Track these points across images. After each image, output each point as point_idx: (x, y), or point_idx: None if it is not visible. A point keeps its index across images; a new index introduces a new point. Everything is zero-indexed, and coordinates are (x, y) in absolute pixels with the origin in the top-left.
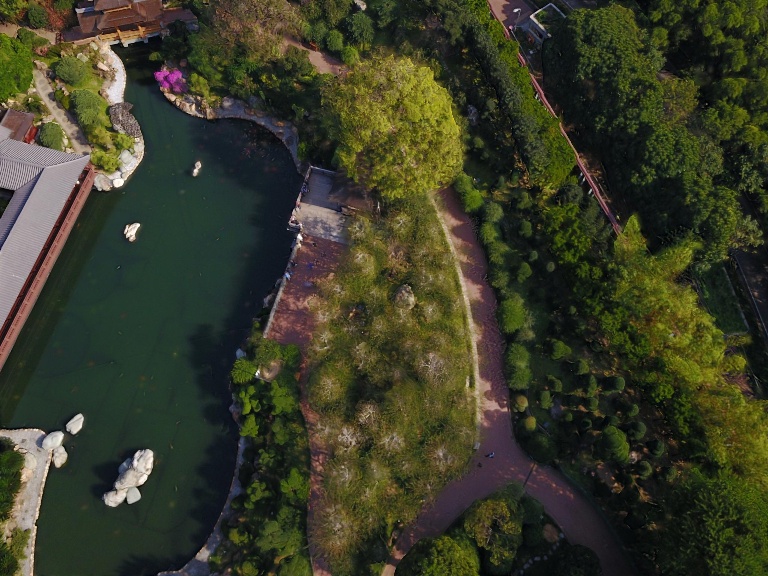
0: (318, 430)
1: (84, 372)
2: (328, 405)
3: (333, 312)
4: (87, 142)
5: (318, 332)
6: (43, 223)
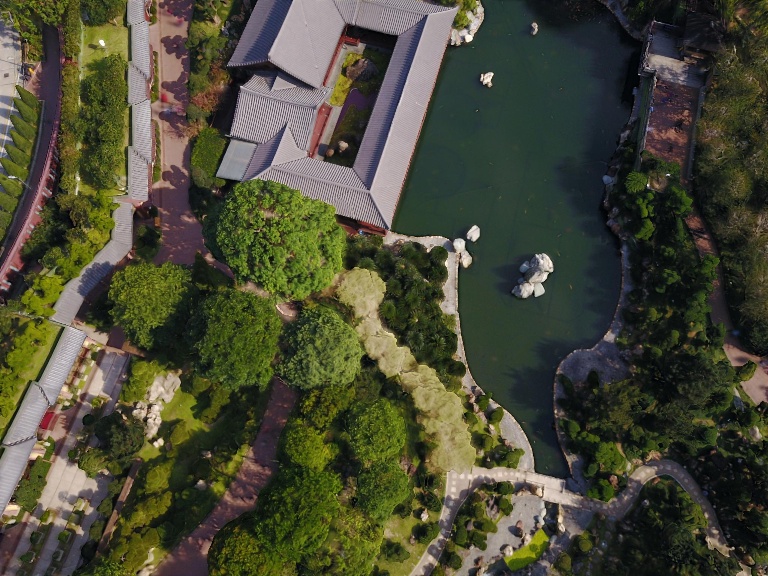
0: (735, 219)
1: (466, 194)
2: (731, 204)
3: (719, 130)
4: (434, 3)
5: (712, 145)
6: (432, 61)
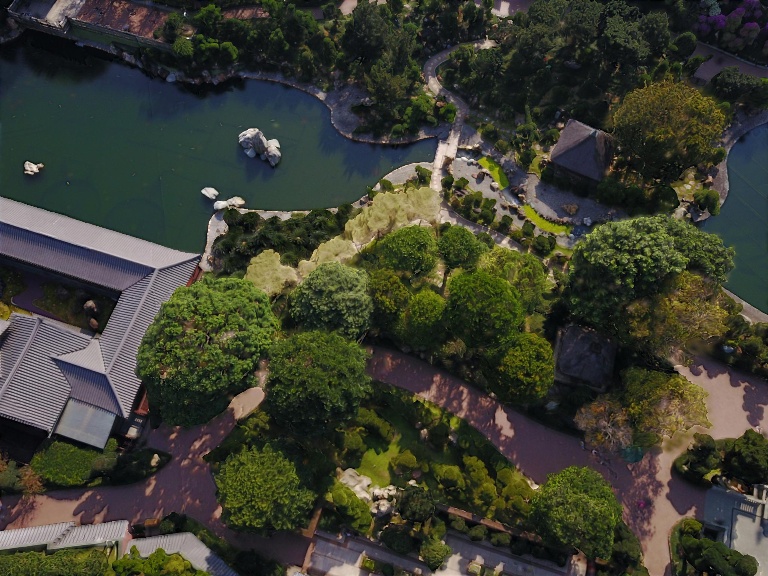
0: None
1: (165, 199)
2: None
3: None
4: None
5: None
6: (3, 205)
